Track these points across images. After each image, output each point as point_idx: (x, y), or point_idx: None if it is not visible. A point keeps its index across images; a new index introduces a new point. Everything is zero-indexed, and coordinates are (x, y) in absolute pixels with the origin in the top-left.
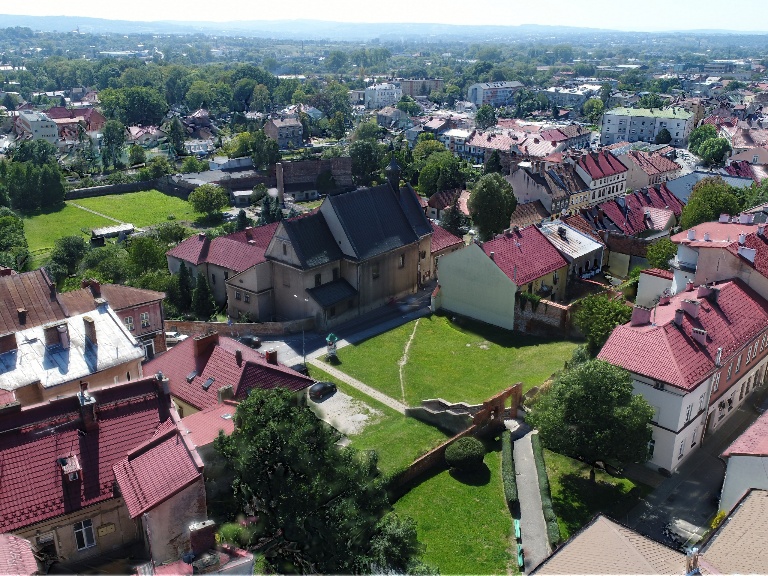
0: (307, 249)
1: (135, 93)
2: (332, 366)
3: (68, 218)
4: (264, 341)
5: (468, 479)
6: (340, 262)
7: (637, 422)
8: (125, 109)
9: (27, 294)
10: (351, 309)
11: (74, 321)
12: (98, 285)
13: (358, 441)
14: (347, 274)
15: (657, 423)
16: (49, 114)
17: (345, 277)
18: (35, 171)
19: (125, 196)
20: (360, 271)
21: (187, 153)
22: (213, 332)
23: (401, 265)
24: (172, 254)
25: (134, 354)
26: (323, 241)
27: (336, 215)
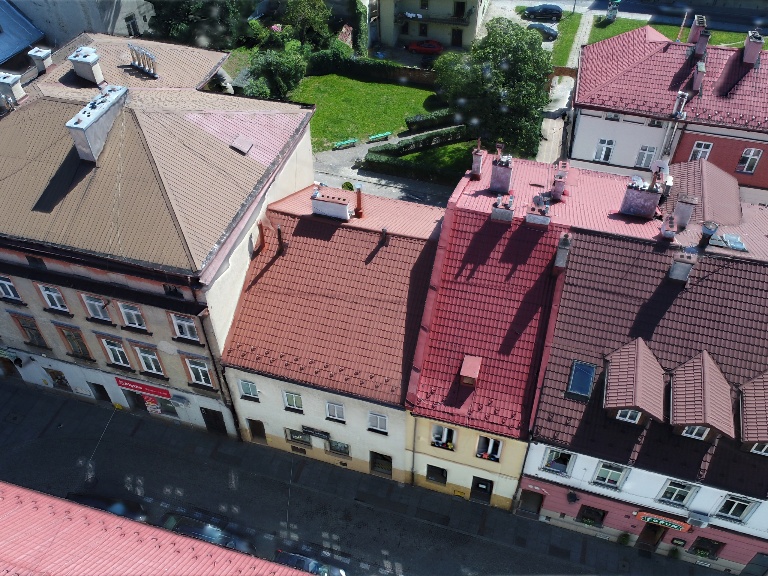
0: None
1: None
2: (592, 26)
3: None
4: None
5: (432, 104)
6: None
7: (459, 82)
8: None
9: None
10: None
11: None
12: None
13: None
14: None
15: (573, 142)
16: None
17: None
18: None
19: None
20: None
21: None
22: None
23: None
24: None
25: None
26: None
27: None
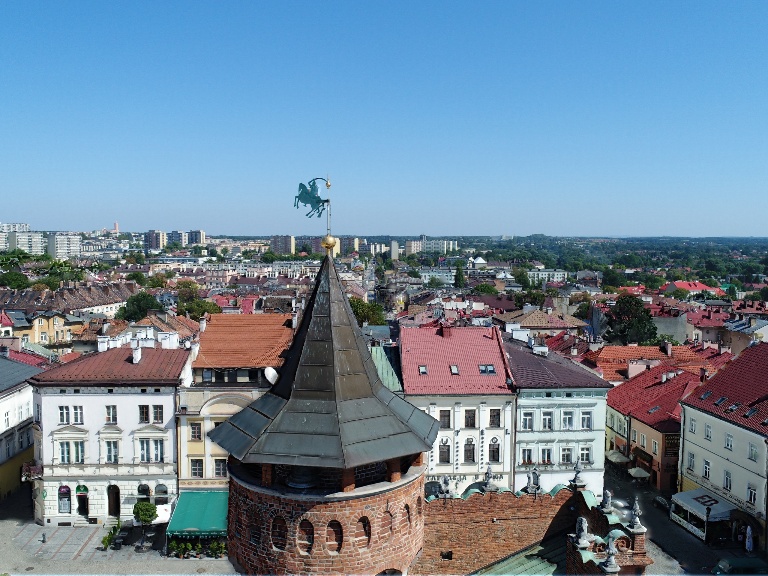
0: None
1: None
2: None
3: None
4: None
5: None
6: None
7: None
8: None
9: None
10: None
11: None
12: None
13: None
14: None
15: None
16: None
17: None
18: None
19: None
20: None
21: None
22: None
23: None
24: None
25: None
26: None
27: None
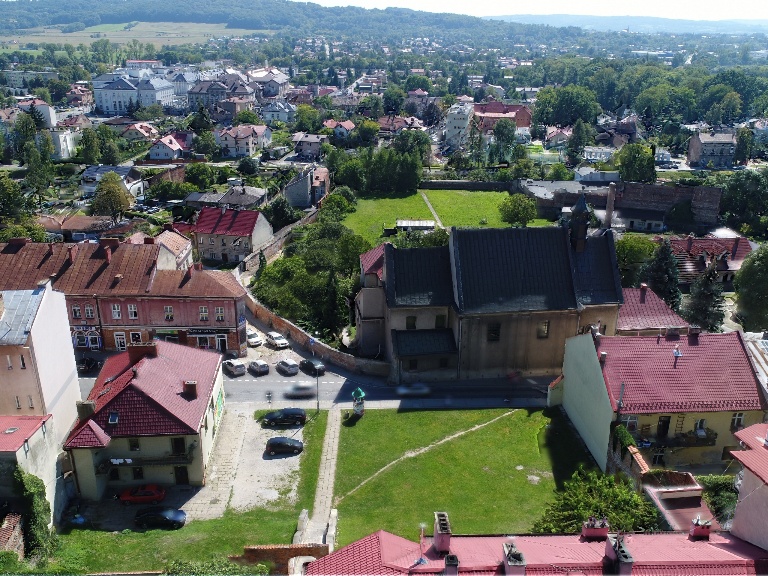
0: (407, 284)
1: (566, 93)
2: (341, 425)
3: (402, 205)
4: (332, 372)
5: None
6: (449, 309)
7: None
8: (552, 108)
9: (134, 263)
10: (445, 368)
11: (7, 295)
12: (190, 270)
13: (222, 520)
14: (454, 326)
15: None
16: (486, 108)
17: (453, 329)
18: (395, 158)
19: (473, 193)
20: (464, 326)
21: (580, 159)
22: (152, 343)
23: (545, 334)
24: (362, 258)
25: (17, 340)
26: (435, 280)
27: (454, 252)
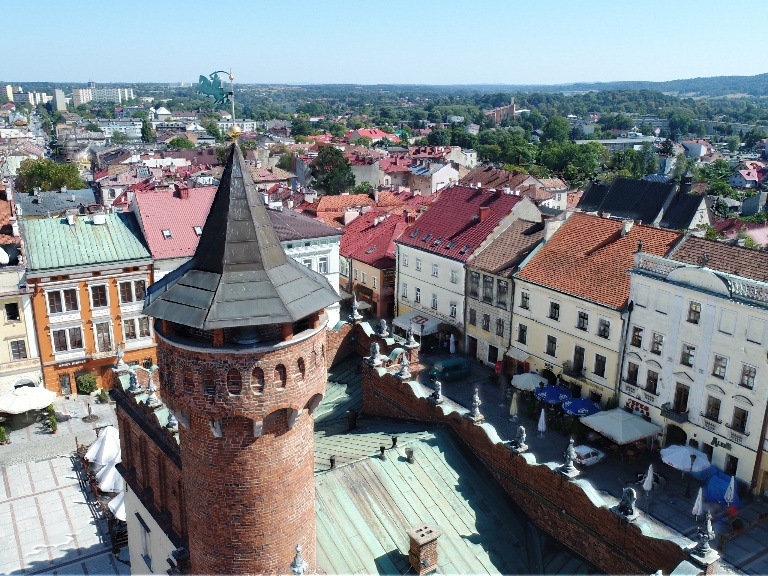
0: (589, 201)
1: None
2: None
3: None
4: None
5: None
6: None
7: None
8: None
9: None
10: None
11: None
12: (530, 186)
13: None
14: None
15: None
16: None
17: None
18: None
19: None
20: None
21: None
22: None
23: None
24: None
25: None
26: None
27: None
